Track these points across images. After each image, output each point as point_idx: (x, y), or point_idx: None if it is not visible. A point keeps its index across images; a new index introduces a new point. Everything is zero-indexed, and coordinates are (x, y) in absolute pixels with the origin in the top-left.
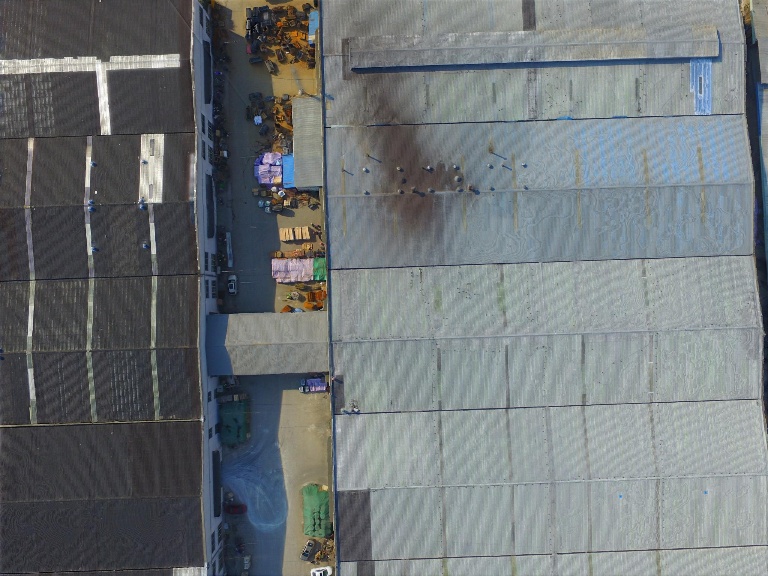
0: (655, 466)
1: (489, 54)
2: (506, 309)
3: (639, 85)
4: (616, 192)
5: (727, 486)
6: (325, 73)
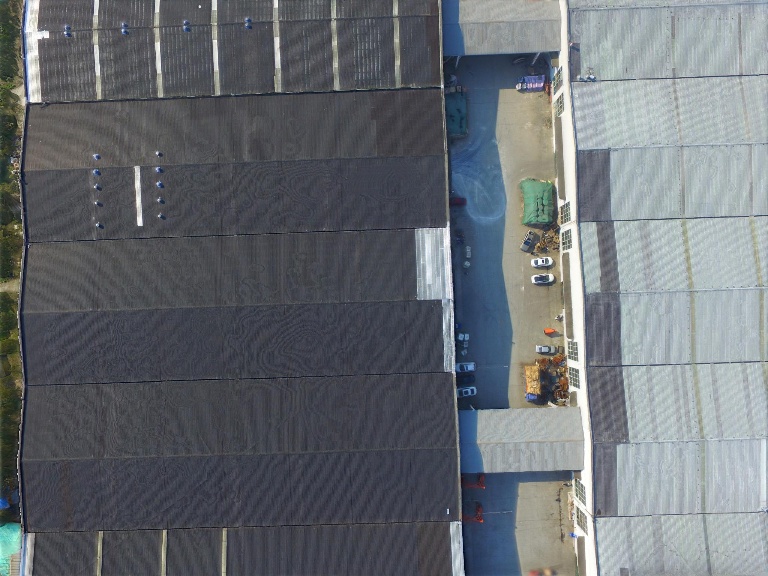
0: None
1: None
2: None
3: None
4: None
5: None
6: None
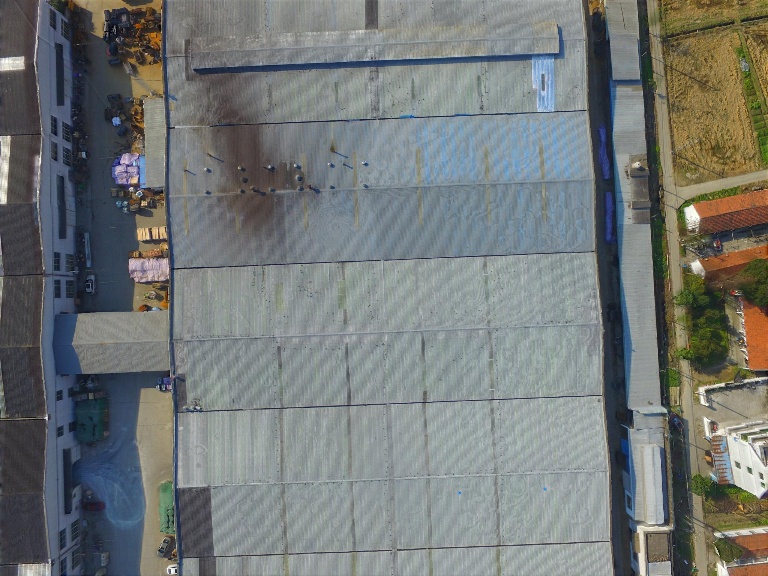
0: (494, 463)
1: (330, 53)
2: (346, 307)
3: (481, 83)
4: (458, 190)
5: (566, 482)
6: (168, 74)
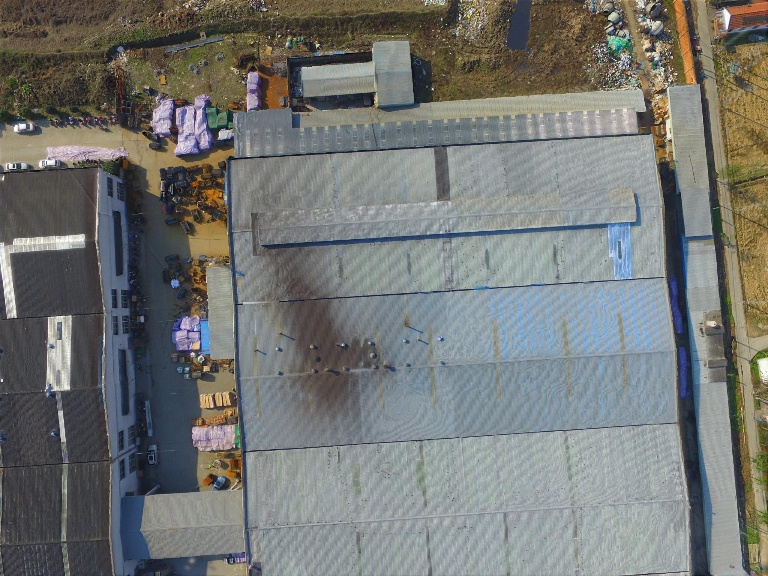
0: None
1: (402, 226)
2: (426, 488)
3: (557, 251)
4: (536, 363)
5: None
6: (235, 249)
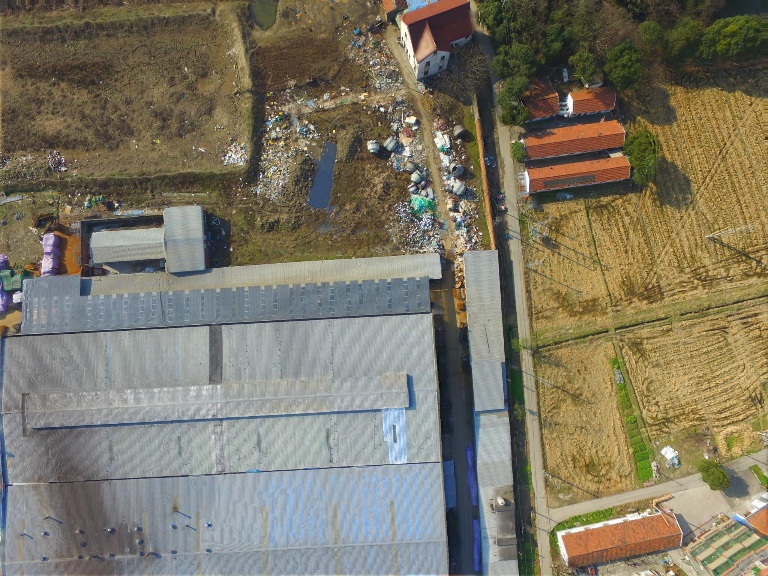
0: None
1: (171, 409)
2: None
3: (330, 435)
4: None
5: None
6: (5, 431)
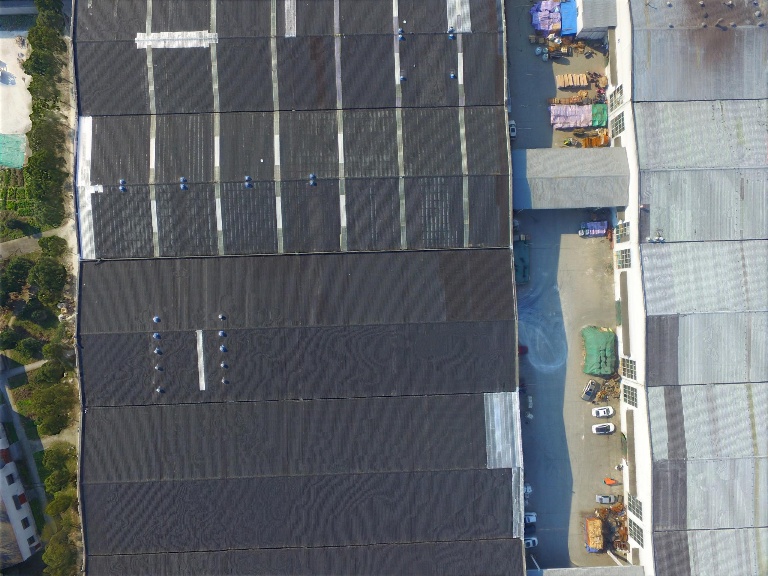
0: None
1: None
2: None
3: None
4: None
5: None
6: None
